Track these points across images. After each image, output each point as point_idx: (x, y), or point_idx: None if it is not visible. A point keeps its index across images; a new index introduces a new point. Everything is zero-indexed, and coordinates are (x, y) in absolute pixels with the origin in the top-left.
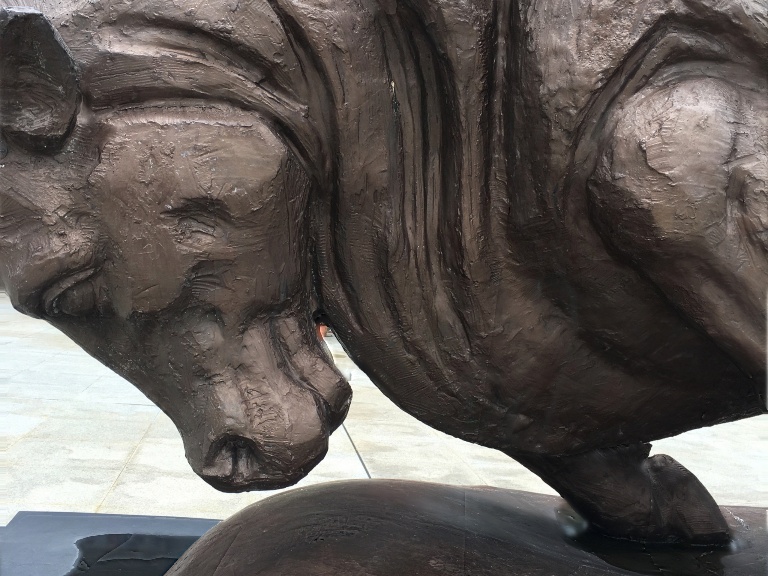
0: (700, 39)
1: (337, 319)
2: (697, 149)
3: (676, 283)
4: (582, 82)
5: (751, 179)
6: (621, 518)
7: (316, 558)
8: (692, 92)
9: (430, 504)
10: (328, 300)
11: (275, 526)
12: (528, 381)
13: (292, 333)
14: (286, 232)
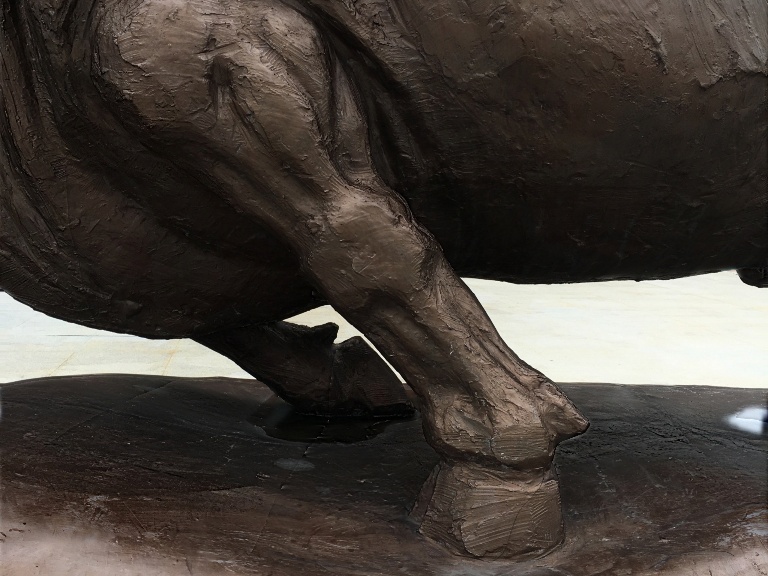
0: None
1: None
2: (168, 41)
3: (195, 168)
4: None
5: (234, 66)
6: (303, 395)
7: None
8: None
9: (101, 391)
10: None
11: None
12: (121, 269)
13: None
14: None
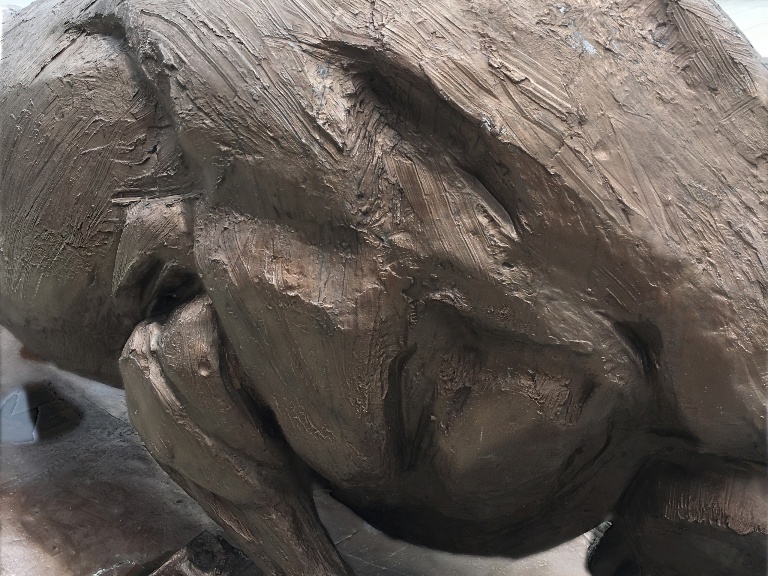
0: None
1: None
2: None
3: None
4: None
5: None
6: None
7: None
8: None
9: None
10: None
11: None
12: None
13: None
14: None
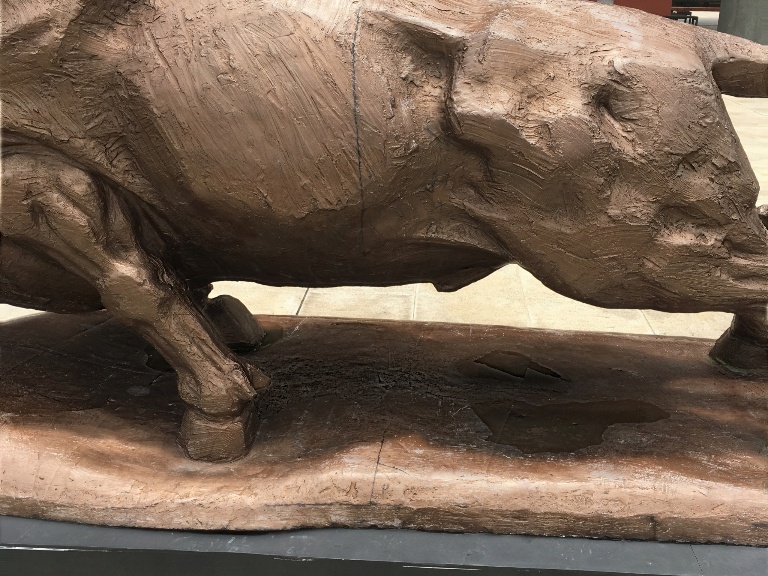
0: (2, 139)
1: None
2: (5, 196)
3: None
4: None
5: (43, 205)
6: None
7: None
8: (3, 166)
9: (55, 332)
10: None
11: None
12: (31, 284)
13: None
14: None
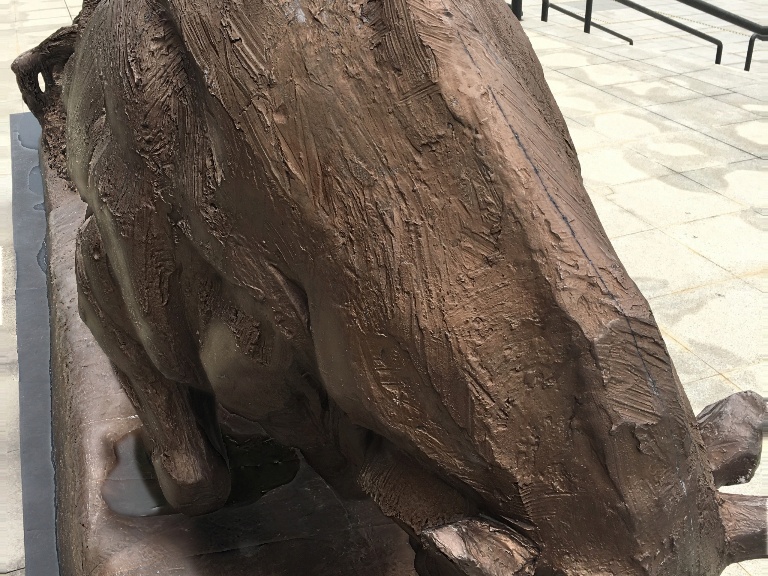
0: None
1: None
2: None
3: None
4: None
5: None
6: None
7: None
8: None
9: (298, 555)
10: None
11: None
12: None
13: None
14: None
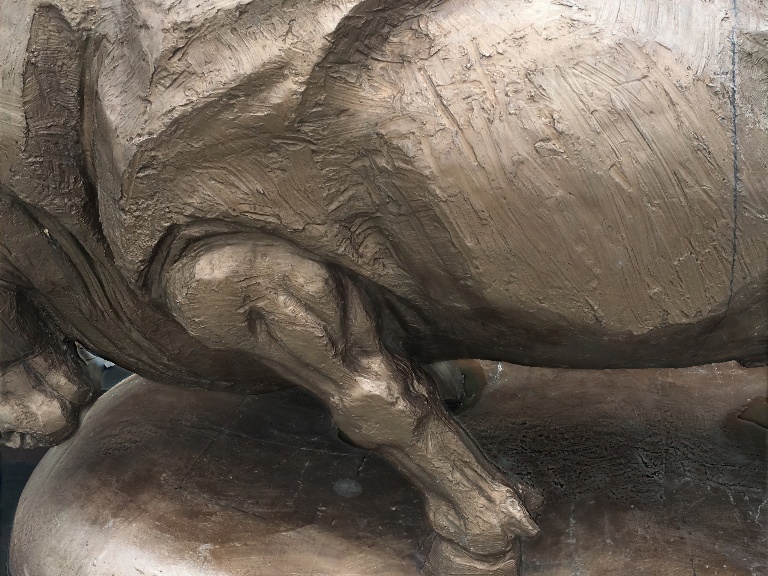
0: (209, 229)
1: (79, 342)
2: (214, 305)
3: None
4: (129, 268)
5: (265, 312)
6: None
7: (97, 472)
8: (210, 264)
9: (219, 396)
10: (68, 335)
11: (98, 432)
12: (214, 371)
13: (40, 366)
14: (4, 327)
